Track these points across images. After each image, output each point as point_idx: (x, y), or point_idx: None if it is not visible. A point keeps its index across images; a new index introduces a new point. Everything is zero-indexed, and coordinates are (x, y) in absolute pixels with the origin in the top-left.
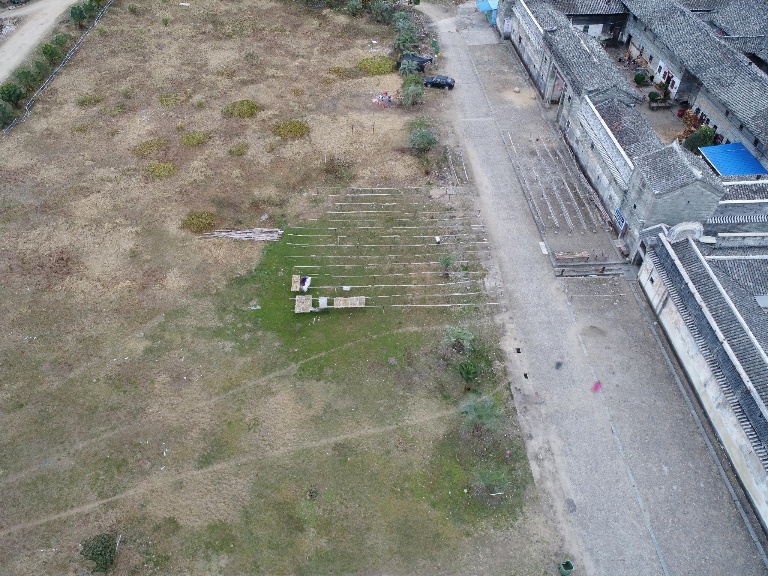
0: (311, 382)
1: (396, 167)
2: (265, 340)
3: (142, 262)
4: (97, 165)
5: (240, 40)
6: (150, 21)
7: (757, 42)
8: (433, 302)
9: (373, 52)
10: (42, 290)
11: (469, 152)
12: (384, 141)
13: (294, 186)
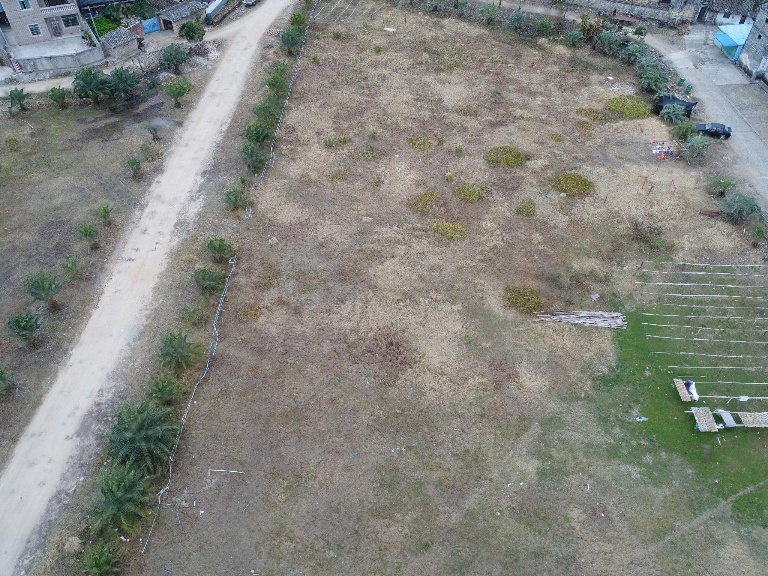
0: (758, 529)
1: (714, 236)
2: (673, 465)
3: (481, 351)
4: (376, 222)
5: (464, 73)
6: (358, 48)
7: None
8: None
9: (616, 90)
10: (385, 384)
11: None
12: (684, 202)
13: (609, 257)
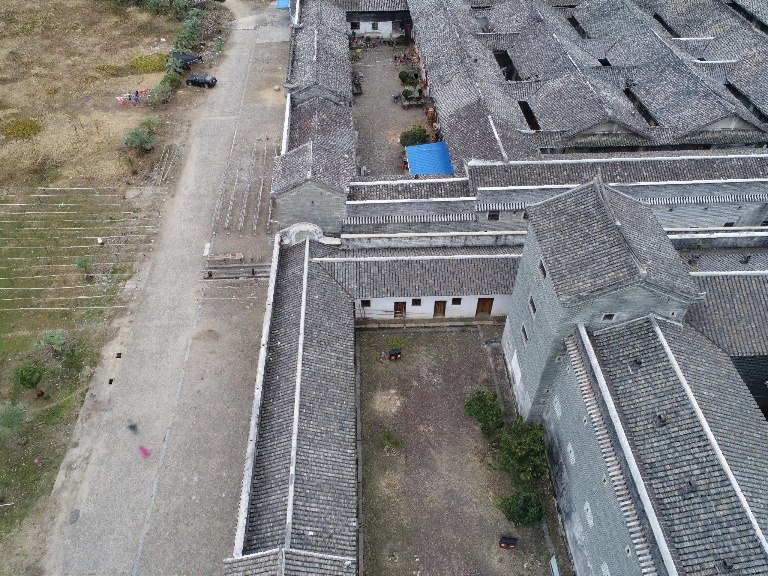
0: None
1: (107, 167)
2: None
3: None
4: None
5: (25, 38)
6: None
7: (510, 39)
8: (61, 305)
9: (155, 50)
10: None
11: (191, 151)
12: (111, 140)
13: None
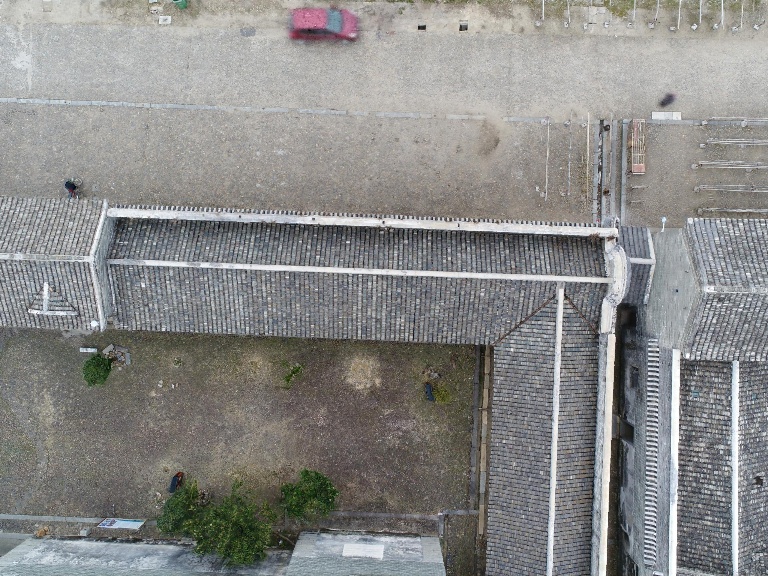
0: None
1: None
2: None
3: None
4: None
5: None
6: None
7: None
8: None
9: None
10: None
11: None
12: None
13: None
